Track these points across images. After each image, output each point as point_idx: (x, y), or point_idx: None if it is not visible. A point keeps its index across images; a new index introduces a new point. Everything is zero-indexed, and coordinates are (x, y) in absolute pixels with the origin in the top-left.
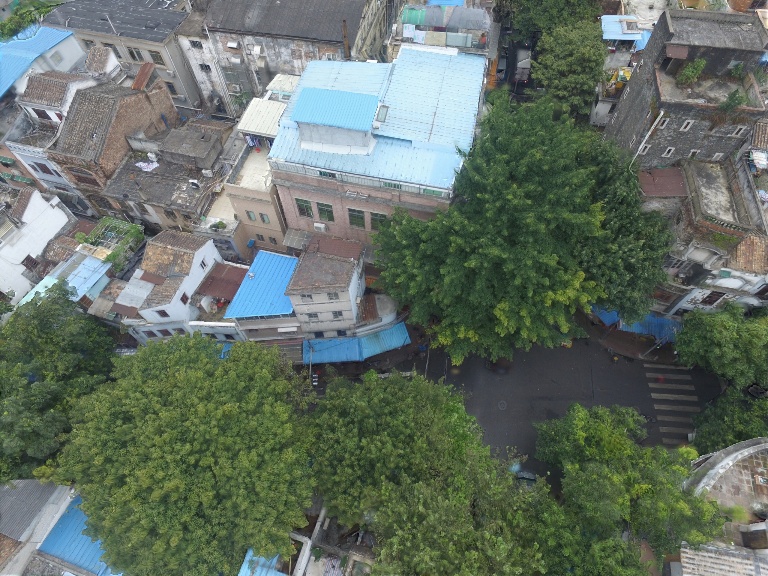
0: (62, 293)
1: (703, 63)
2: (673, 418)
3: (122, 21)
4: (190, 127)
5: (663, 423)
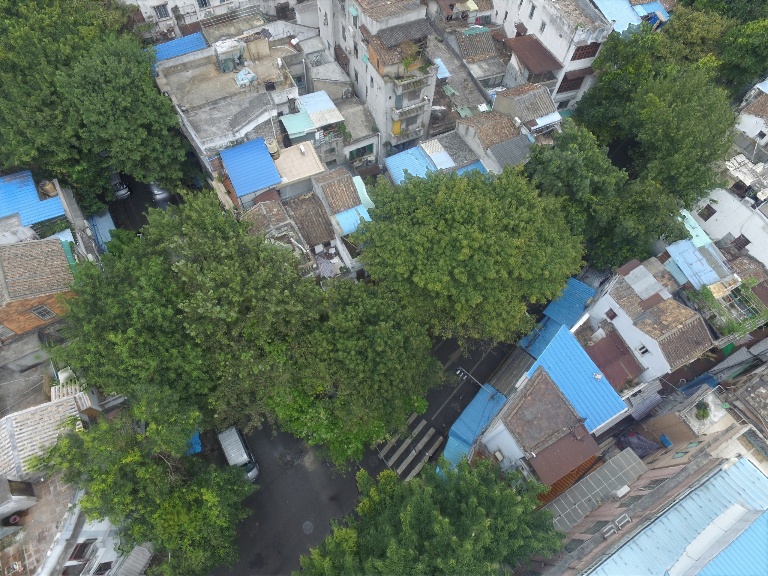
0: (671, 228)
1: None
2: None
3: None
4: None
5: None
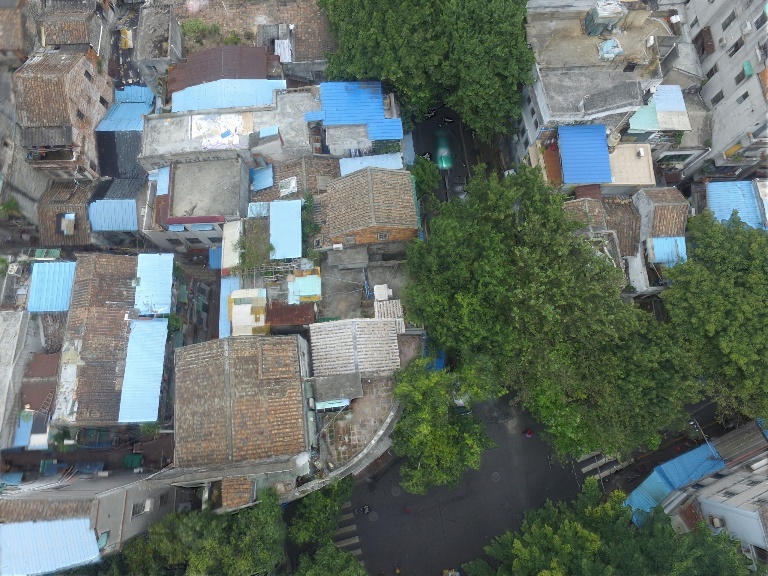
0: None
1: None
2: None
3: None
4: None
5: (348, 511)
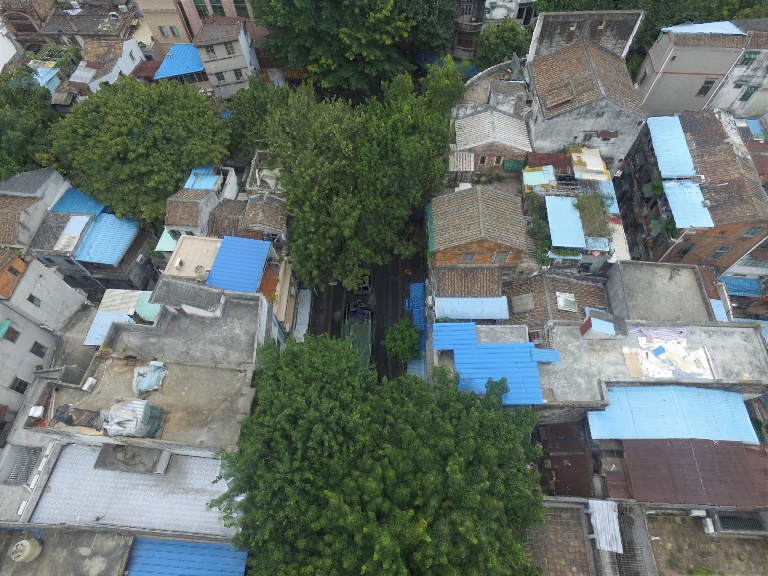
0: (28, 69)
1: None
2: None
3: None
4: None
5: None
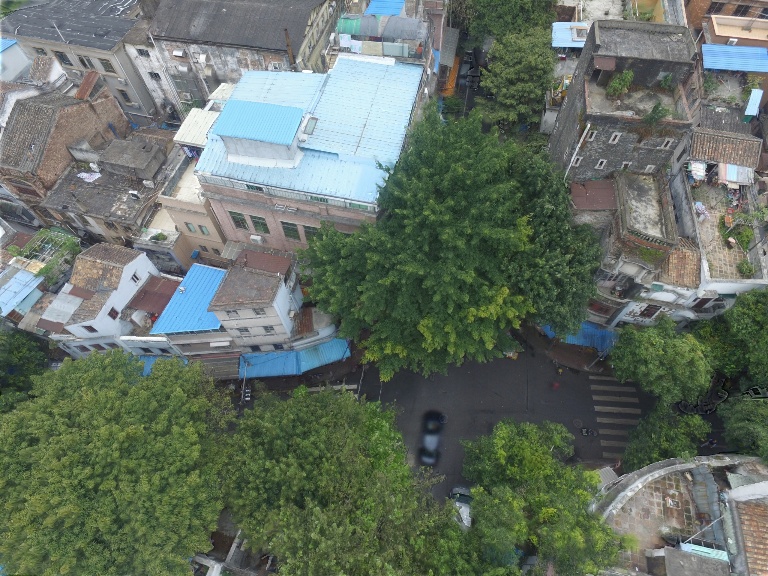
0: None
1: (630, 75)
2: (615, 431)
3: (72, 29)
4: (135, 137)
5: (604, 437)
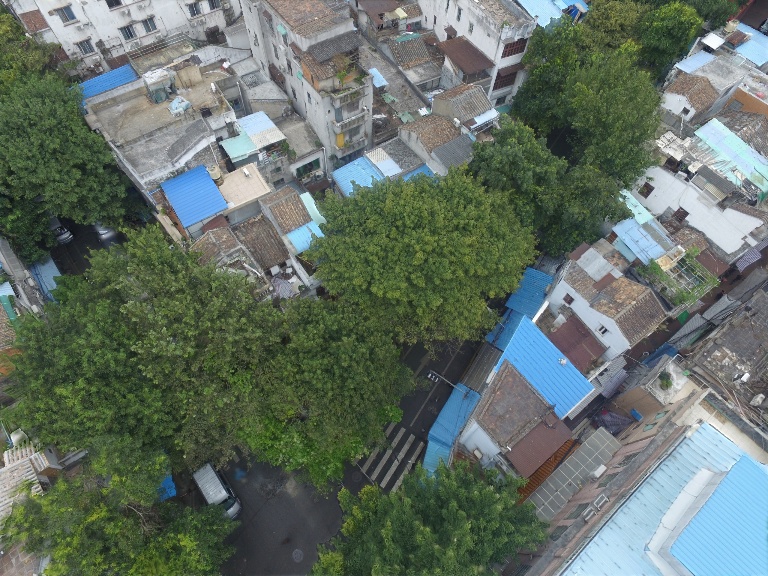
0: (613, 209)
1: None
2: None
3: None
4: None
5: None
